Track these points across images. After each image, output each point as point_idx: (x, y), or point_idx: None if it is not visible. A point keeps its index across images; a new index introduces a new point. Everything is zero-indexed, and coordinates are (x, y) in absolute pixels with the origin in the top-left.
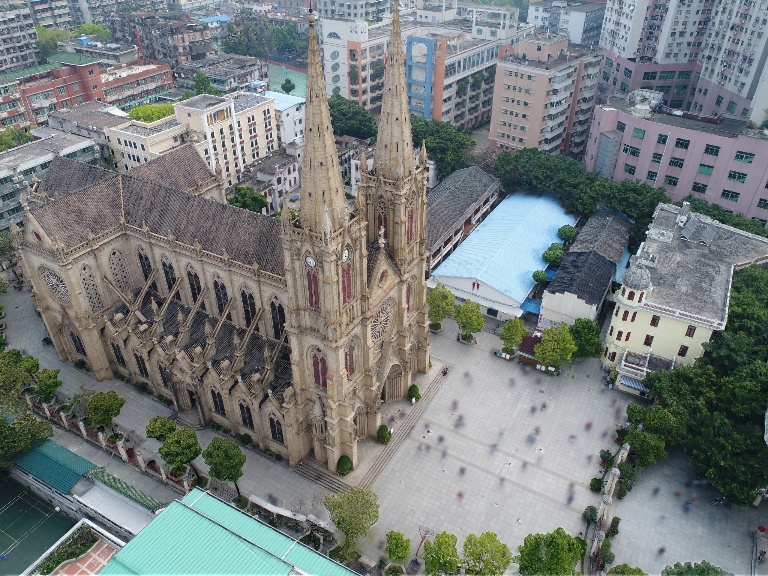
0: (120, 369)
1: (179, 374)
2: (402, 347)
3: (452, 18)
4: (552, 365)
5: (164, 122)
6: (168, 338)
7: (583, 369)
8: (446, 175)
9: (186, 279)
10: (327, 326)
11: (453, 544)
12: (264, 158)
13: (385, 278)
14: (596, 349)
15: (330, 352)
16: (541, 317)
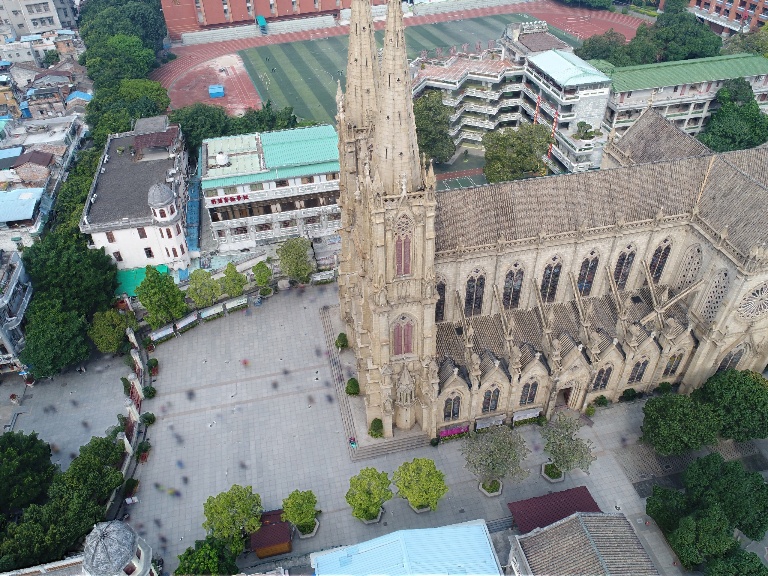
0: None
1: None
2: None
3: None
4: None
5: None
6: None
7: None
8: None
9: None
10: None
11: None
12: None
13: None
14: None
15: None
16: None
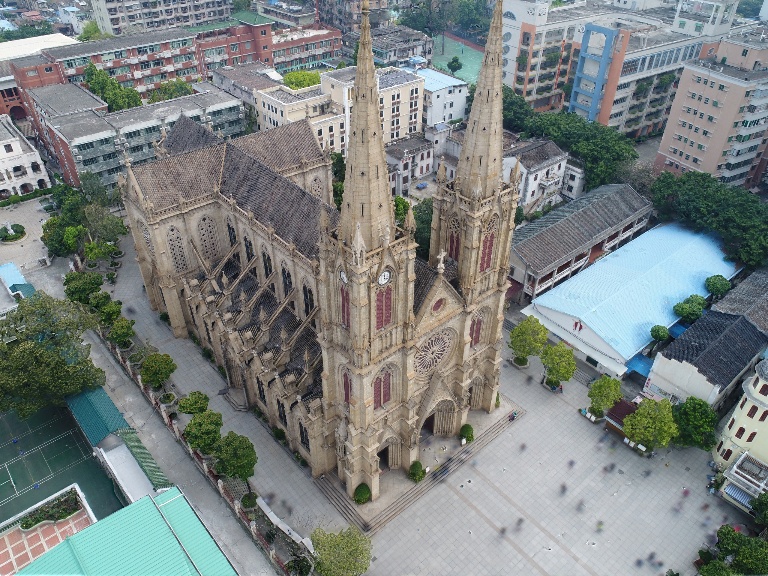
0: (195, 330)
1: (232, 353)
2: (459, 382)
3: (657, 5)
4: (643, 444)
5: (309, 90)
6: (227, 315)
7: (684, 458)
8: (592, 188)
9: (261, 259)
10: (353, 350)
11: None
12: (400, 139)
13: (443, 306)
14: (706, 440)
15: (354, 377)
16: (649, 381)
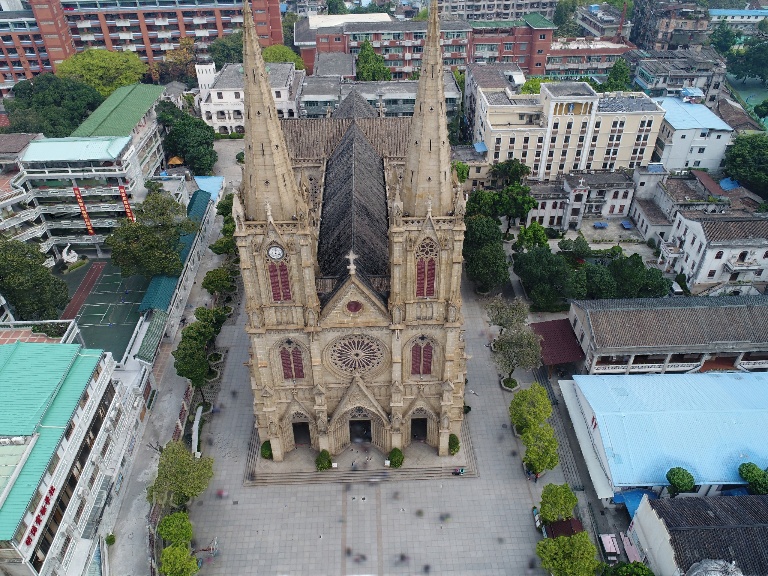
0: None
1: None
2: (391, 400)
3: None
4: None
5: (529, 98)
6: None
7: None
8: None
9: None
10: None
11: (181, 568)
12: (602, 170)
13: (362, 311)
14: None
15: None
16: (632, 525)
